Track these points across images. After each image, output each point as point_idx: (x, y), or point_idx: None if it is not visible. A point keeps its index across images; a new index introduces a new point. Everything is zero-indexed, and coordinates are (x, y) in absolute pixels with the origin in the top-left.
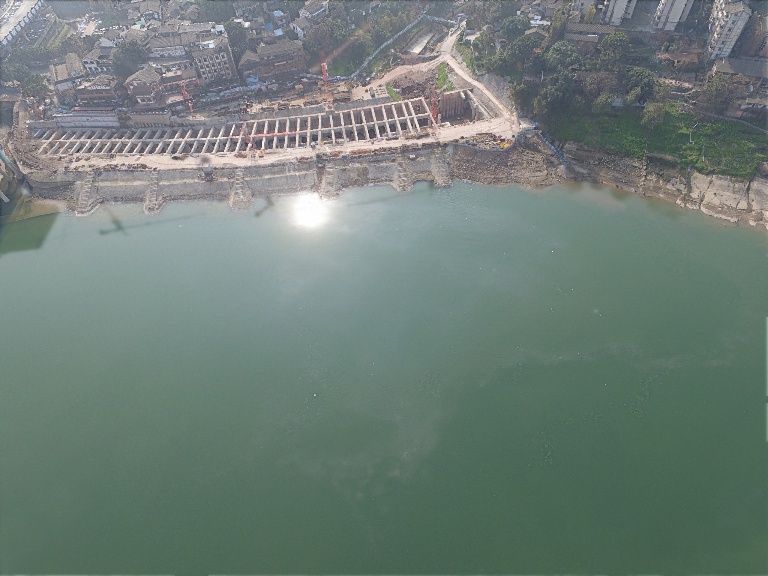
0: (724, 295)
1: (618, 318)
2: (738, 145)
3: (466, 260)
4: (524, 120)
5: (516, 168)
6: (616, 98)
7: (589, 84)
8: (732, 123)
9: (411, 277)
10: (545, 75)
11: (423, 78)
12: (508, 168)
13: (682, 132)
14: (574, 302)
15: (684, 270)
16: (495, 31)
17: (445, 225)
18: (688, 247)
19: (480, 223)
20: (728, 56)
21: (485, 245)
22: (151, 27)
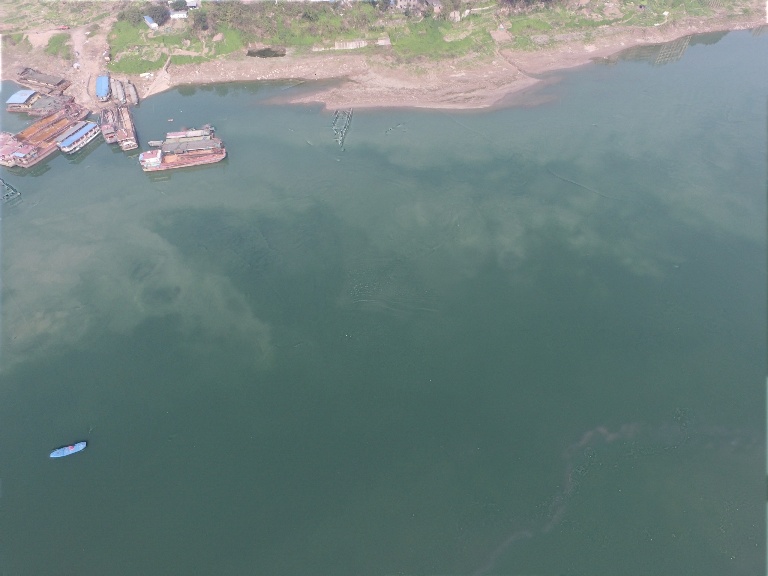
0: None
1: None
2: None
3: None
4: None
5: None
6: None
7: None
8: None
9: None
10: None
11: None
12: None
13: None
14: None
15: None
16: None
17: None
18: None
19: None
20: None
21: None
22: None
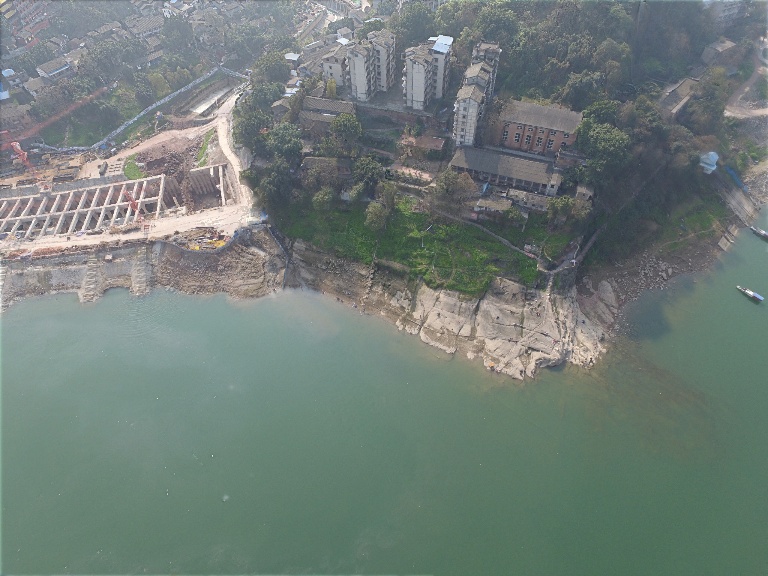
0: (390, 468)
1: (246, 504)
2: (470, 254)
3: (105, 409)
4: (254, 211)
5: (227, 273)
6: (344, 192)
7: (309, 176)
8: (467, 227)
9: (25, 435)
10: (270, 161)
11: (183, 147)
12: (217, 274)
13: (412, 236)
14: (203, 478)
15: (358, 428)
16: None
17: (111, 353)
18: (379, 392)
19: (151, 352)
20: (473, 144)
21: (140, 385)
22: None
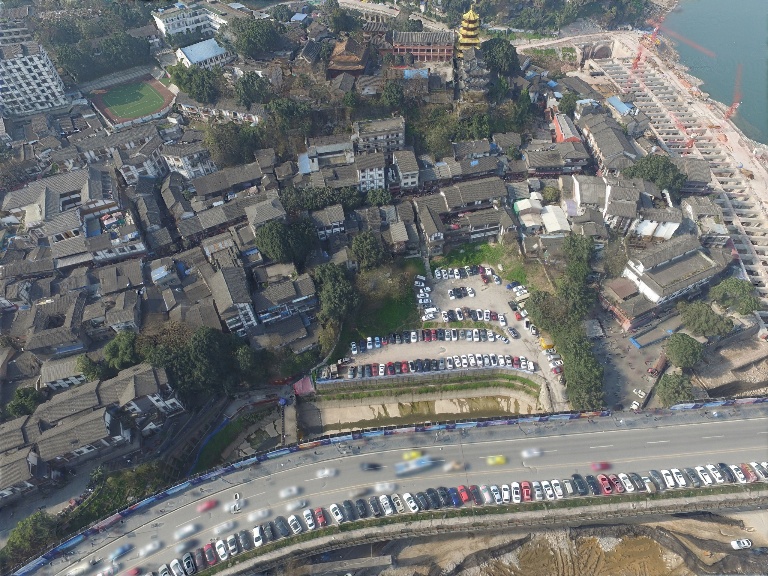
0: None
1: None
2: None
3: (761, 65)
4: (622, 26)
5: None
6: None
7: None
8: None
9: None
10: None
11: None
12: None
13: None
14: None
15: (727, 17)
16: (522, 8)
17: (729, 71)
18: (707, 15)
19: (723, 59)
20: None
21: (742, 59)
22: (539, 183)
